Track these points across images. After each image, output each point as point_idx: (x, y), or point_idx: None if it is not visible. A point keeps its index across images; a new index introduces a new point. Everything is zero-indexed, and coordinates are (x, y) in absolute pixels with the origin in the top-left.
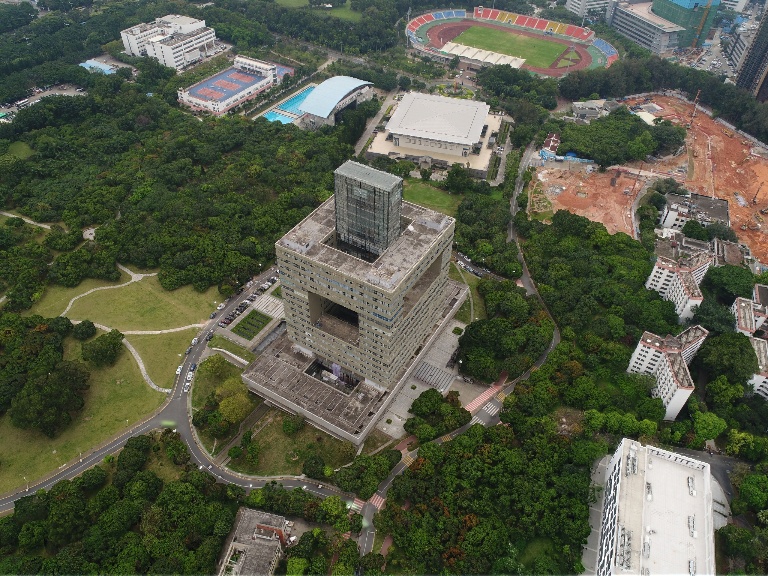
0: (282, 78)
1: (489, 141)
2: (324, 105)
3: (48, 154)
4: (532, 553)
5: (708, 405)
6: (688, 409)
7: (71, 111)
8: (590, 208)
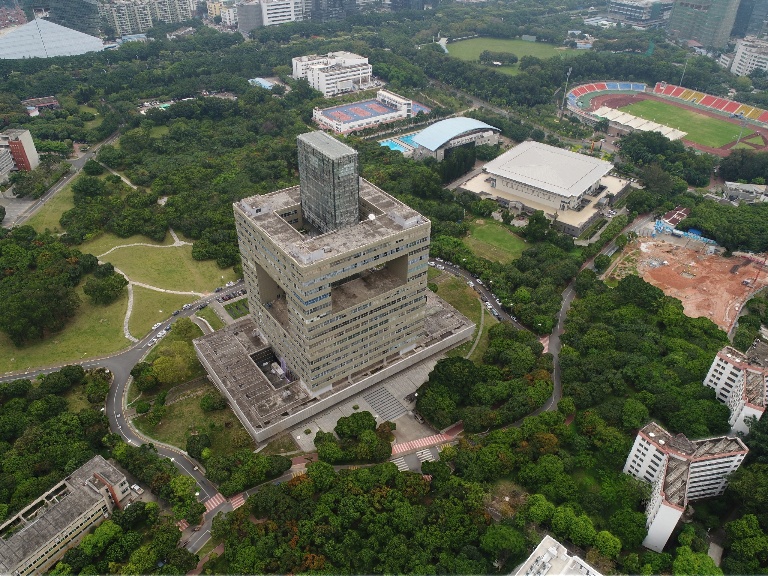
0: (417, 115)
1: (599, 201)
2: (436, 139)
3: (177, 137)
4: None
5: (724, 552)
6: None
7: (217, 110)
8: (687, 289)
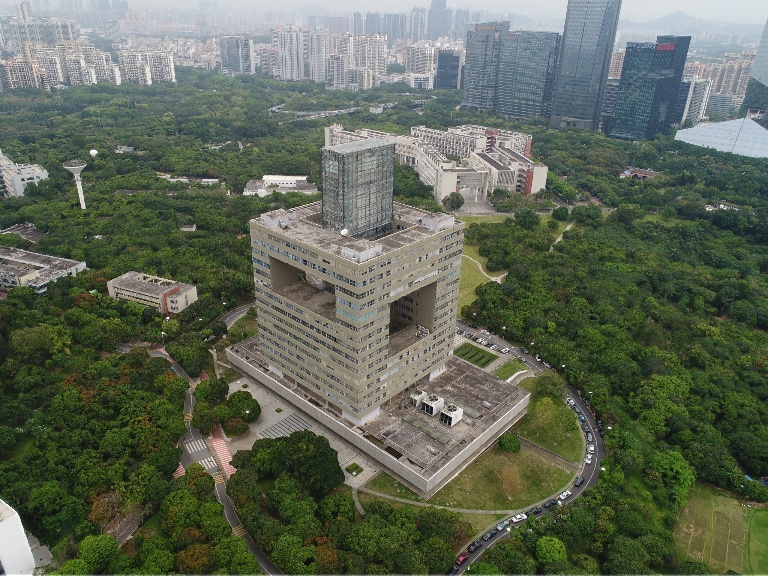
0: None
1: None
2: None
3: None
4: None
5: None
6: None
7: (766, 234)
8: None
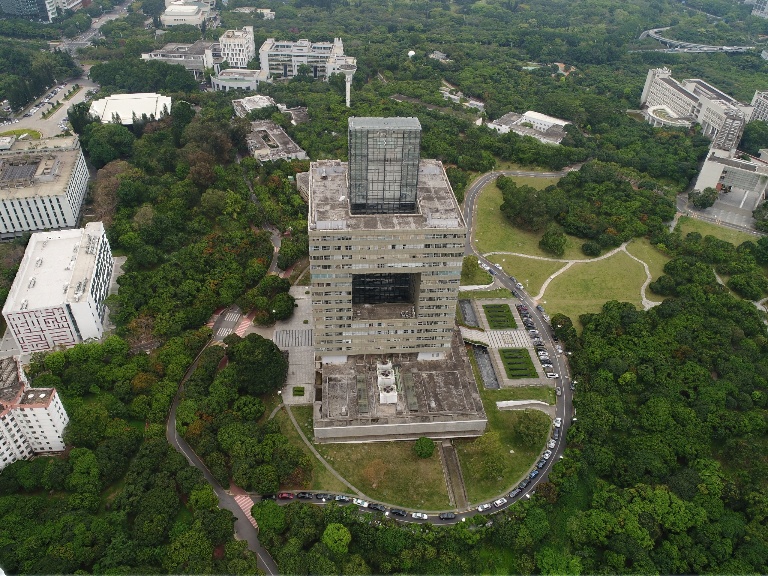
0: None
1: None
2: None
3: None
4: None
5: None
6: None
7: None
8: None
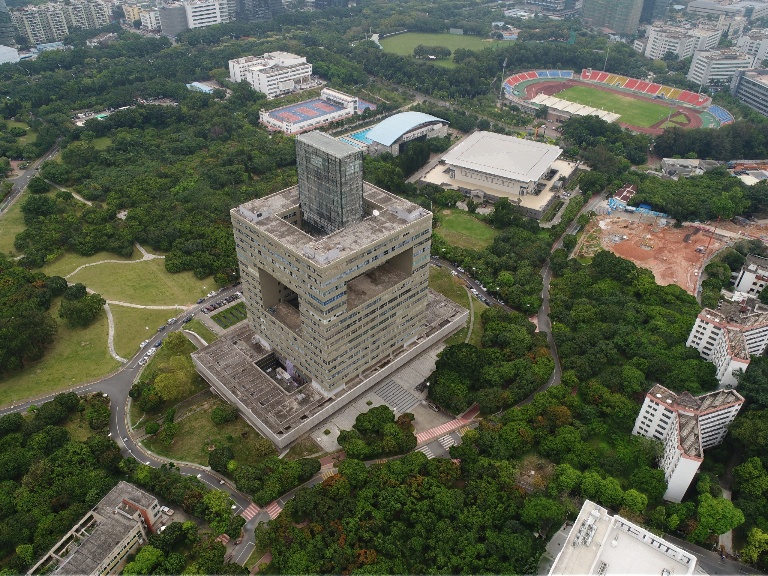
0: (363, 112)
1: (554, 184)
2: (390, 134)
3: (122, 148)
4: None
5: (734, 495)
6: None
7: (159, 118)
8: (650, 260)
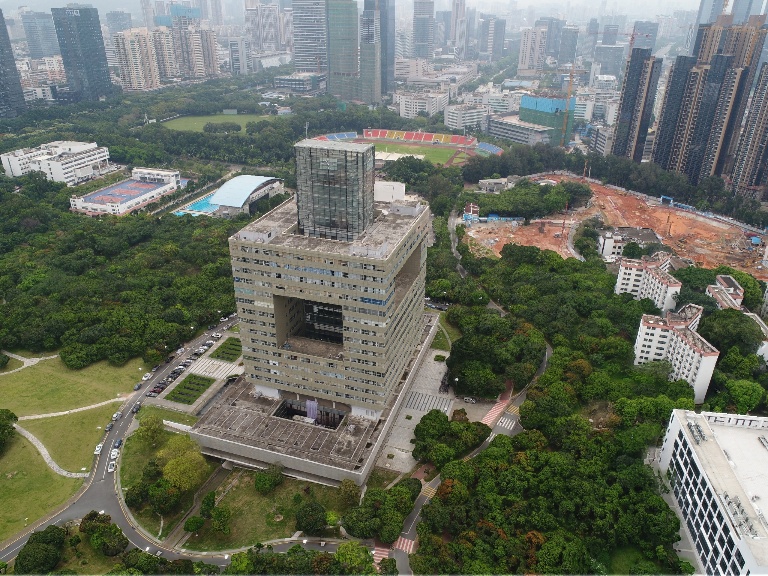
0: (186, 185)
1: None
2: (237, 196)
3: None
4: (620, 568)
5: None
6: (714, 386)
7: None
8: None
